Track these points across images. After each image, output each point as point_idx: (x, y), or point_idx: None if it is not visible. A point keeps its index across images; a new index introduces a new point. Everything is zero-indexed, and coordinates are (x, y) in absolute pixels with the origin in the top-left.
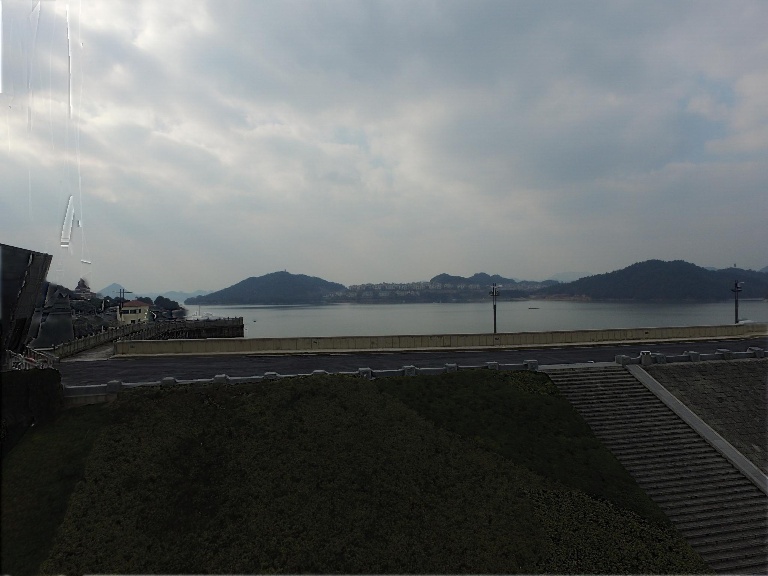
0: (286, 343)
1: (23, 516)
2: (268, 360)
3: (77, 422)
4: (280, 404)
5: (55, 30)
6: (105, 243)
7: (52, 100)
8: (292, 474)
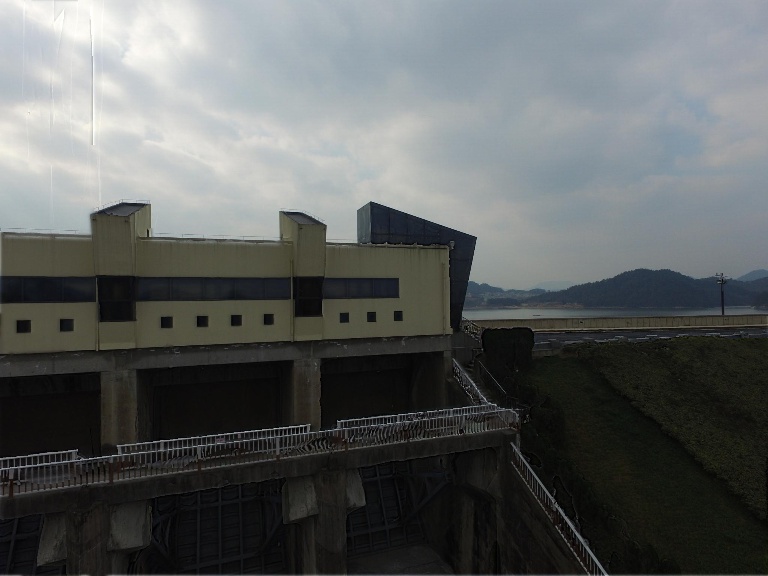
0: (558, 323)
1: (604, 426)
2: (571, 334)
3: (558, 367)
4: (697, 355)
5: (76, 38)
6: None
7: (72, 107)
8: (767, 398)
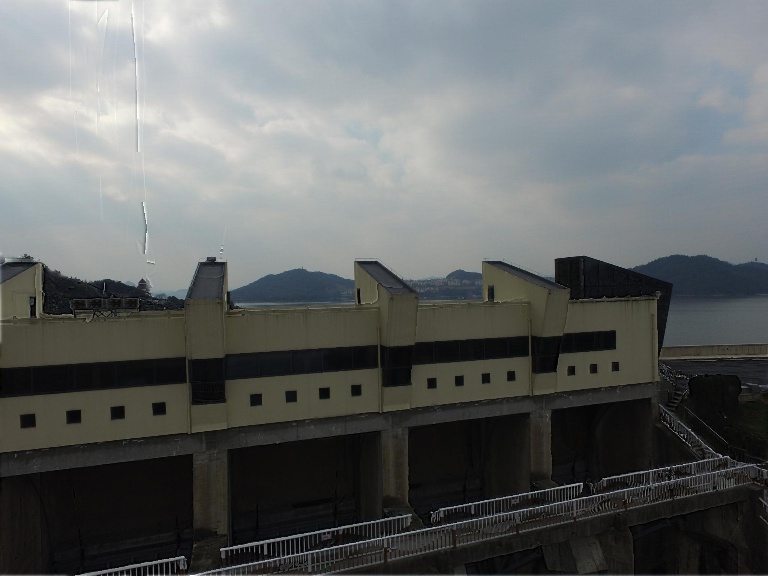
0: (704, 350)
1: None
2: None
3: (767, 415)
4: None
5: None
6: (260, 249)
7: None
8: None
